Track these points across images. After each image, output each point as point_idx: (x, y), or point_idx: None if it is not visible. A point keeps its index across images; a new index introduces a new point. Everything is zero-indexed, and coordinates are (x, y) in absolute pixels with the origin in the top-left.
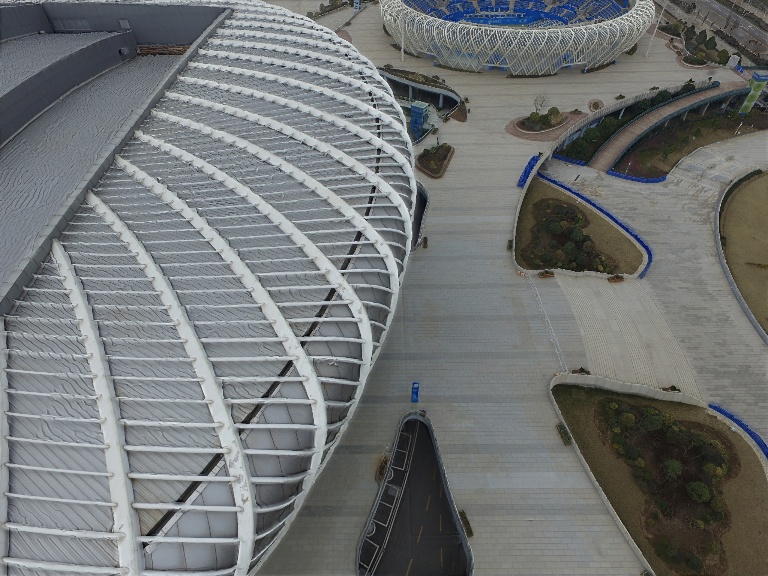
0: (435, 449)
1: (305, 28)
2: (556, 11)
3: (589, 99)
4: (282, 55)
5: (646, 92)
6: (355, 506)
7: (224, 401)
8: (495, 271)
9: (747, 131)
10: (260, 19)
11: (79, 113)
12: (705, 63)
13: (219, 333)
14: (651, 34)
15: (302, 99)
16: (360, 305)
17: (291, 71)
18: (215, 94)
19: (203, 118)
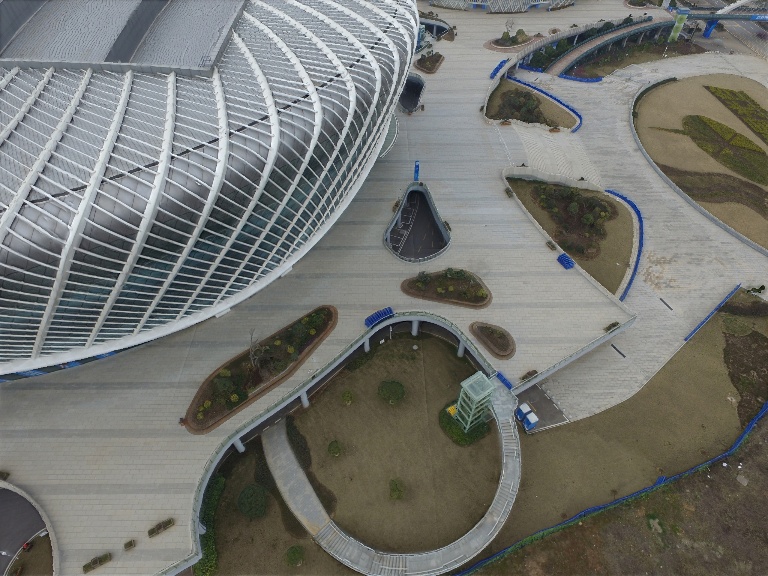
0: (429, 202)
1: None
2: None
3: (550, 28)
4: None
5: (594, 23)
6: (381, 221)
7: (338, 59)
8: (471, 122)
9: (672, 55)
10: None
11: None
12: (645, 5)
13: (331, 42)
14: None
15: None
16: (393, 45)
17: None
18: None
19: None
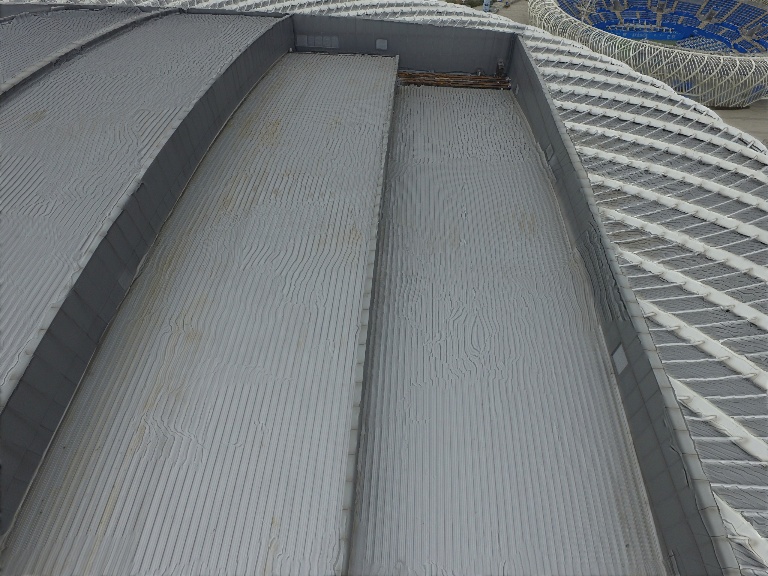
0: None
1: (621, 67)
2: (713, 29)
3: None
4: (648, 111)
5: None
6: None
7: None
8: None
9: None
10: (556, 50)
11: (410, 176)
12: None
13: None
14: None
15: (748, 189)
16: None
17: (686, 139)
18: (636, 176)
19: (670, 222)
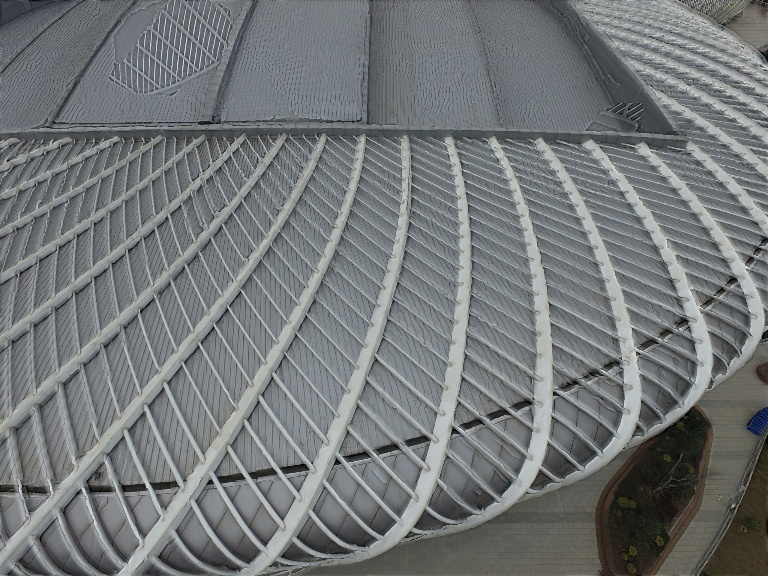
0: None
1: None
2: None
3: None
4: None
5: (767, 44)
6: None
7: None
8: None
9: None
10: None
11: None
12: None
13: (751, 93)
14: (750, 2)
15: None
16: None
17: None
18: None
19: (609, 7)
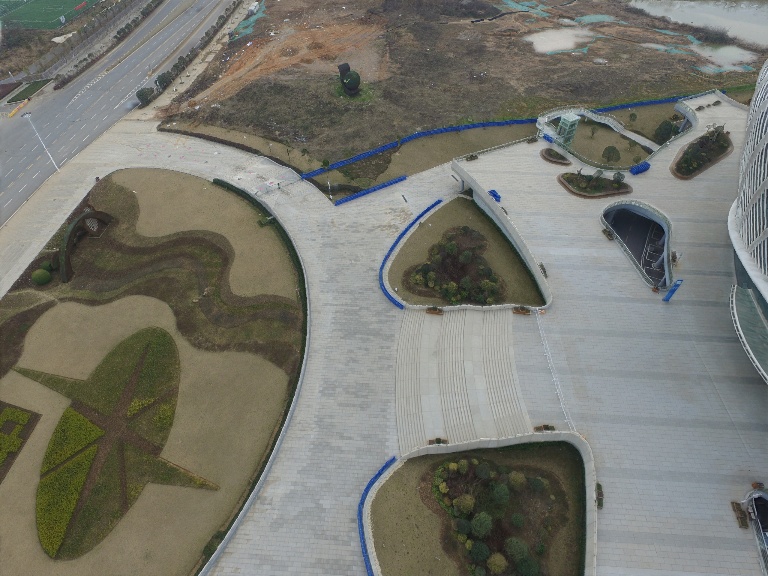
0: None
1: None
2: None
3: None
4: None
5: None
6: (681, 246)
7: None
8: (615, 445)
9: None
10: None
11: None
12: None
13: None
14: None
15: None
16: None
17: None
18: None
19: None
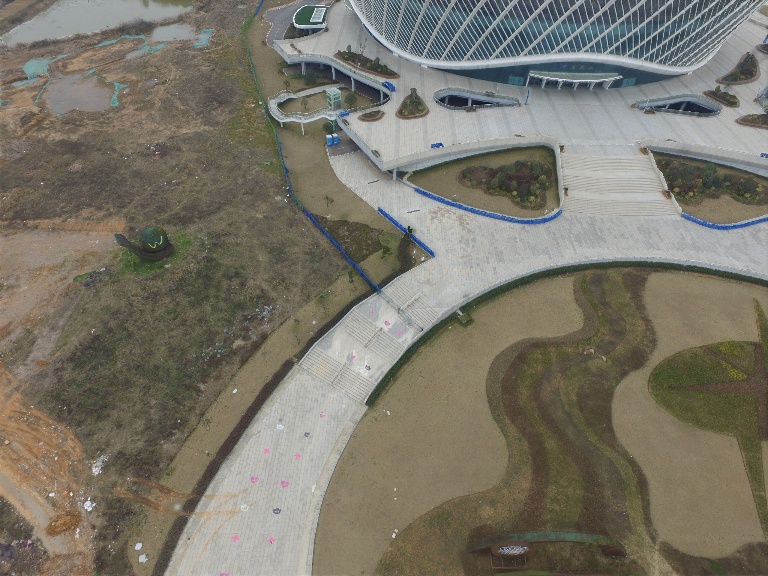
0: None
1: None
2: None
3: None
4: None
5: None
6: None
7: None
8: (637, 134)
9: None
10: None
11: None
12: None
13: None
14: None
15: None
16: None
17: None
18: None
19: None
